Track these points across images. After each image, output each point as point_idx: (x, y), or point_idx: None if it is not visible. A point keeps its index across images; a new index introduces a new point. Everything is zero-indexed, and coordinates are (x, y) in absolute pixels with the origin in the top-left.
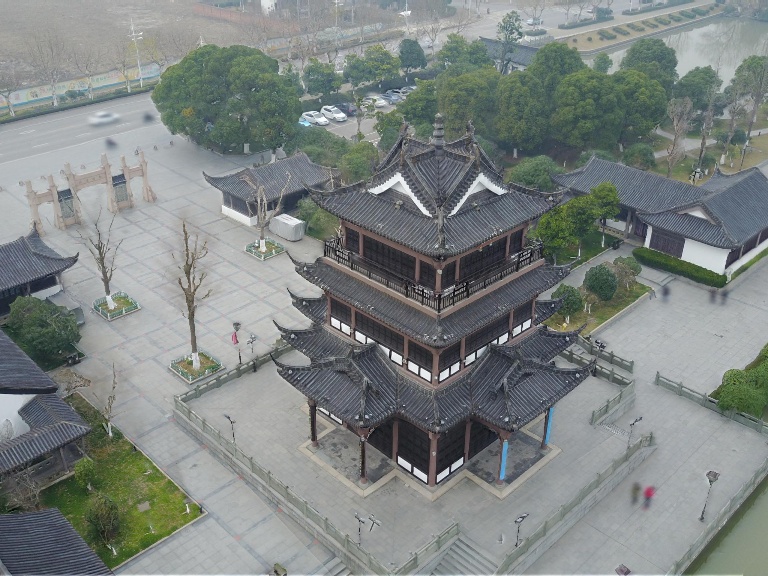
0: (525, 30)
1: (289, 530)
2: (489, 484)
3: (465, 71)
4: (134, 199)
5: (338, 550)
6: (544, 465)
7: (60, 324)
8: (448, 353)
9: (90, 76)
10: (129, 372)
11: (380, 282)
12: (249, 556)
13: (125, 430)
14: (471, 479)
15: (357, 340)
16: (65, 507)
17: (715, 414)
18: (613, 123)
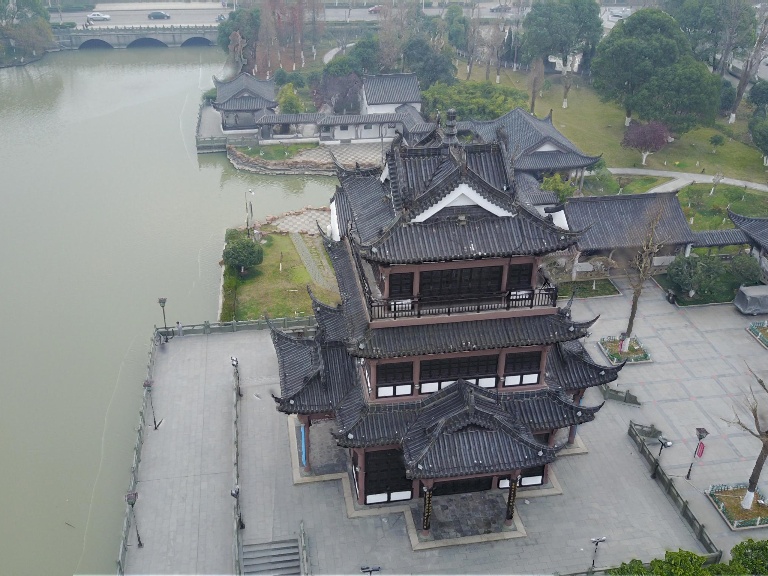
0: None
1: None
2: None
3: None
4: None
5: None
6: None
7: None
8: None
9: None
10: (640, 321)
11: None
12: None
13: None
14: None
15: None
16: None
17: None
18: None
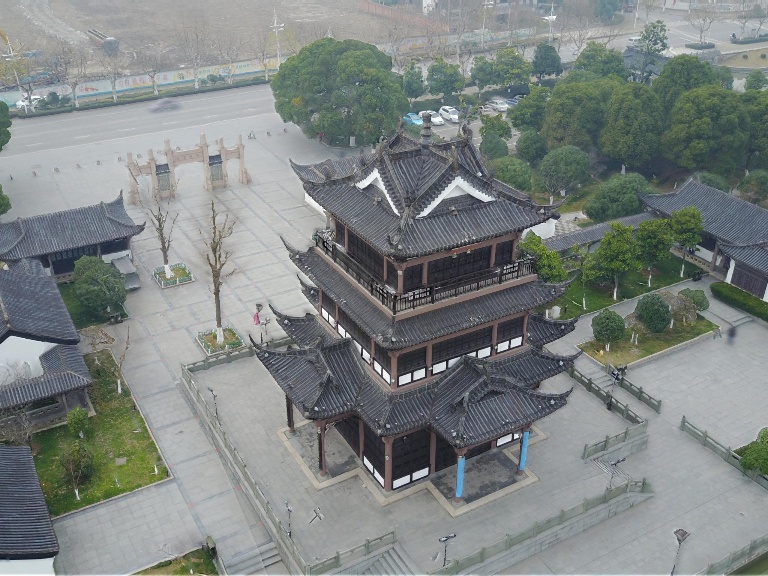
0: (670, 41)
1: (240, 508)
2: (446, 500)
3: (584, 80)
4: (231, 179)
5: (273, 535)
6: (513, 491)
7: (109, 285)
8: (410, 358)
9: (231, 62)
10: (160, 337)
11: (354, 277)
12: (193, 525)
13: (135, 389)
14: (431, 491)
15: (339, 333)
16: (55, 449)
17: (736, 472)
18: (731, 146)
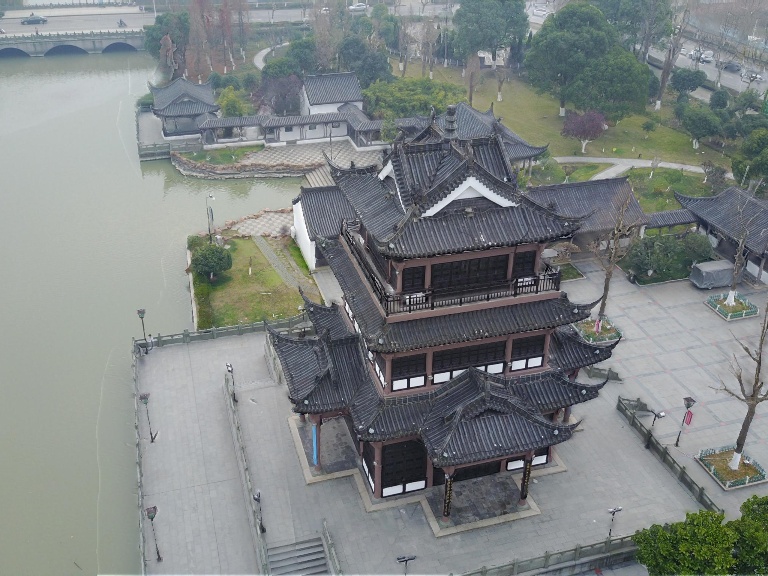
0: None
1: None
2: None
3: None
4: None
5: None
6: None
7: None
8: None
9: None
10: (607, 302)
11: None
12: None
13: None
14: None
15: None
16: None
17: None
18: None
